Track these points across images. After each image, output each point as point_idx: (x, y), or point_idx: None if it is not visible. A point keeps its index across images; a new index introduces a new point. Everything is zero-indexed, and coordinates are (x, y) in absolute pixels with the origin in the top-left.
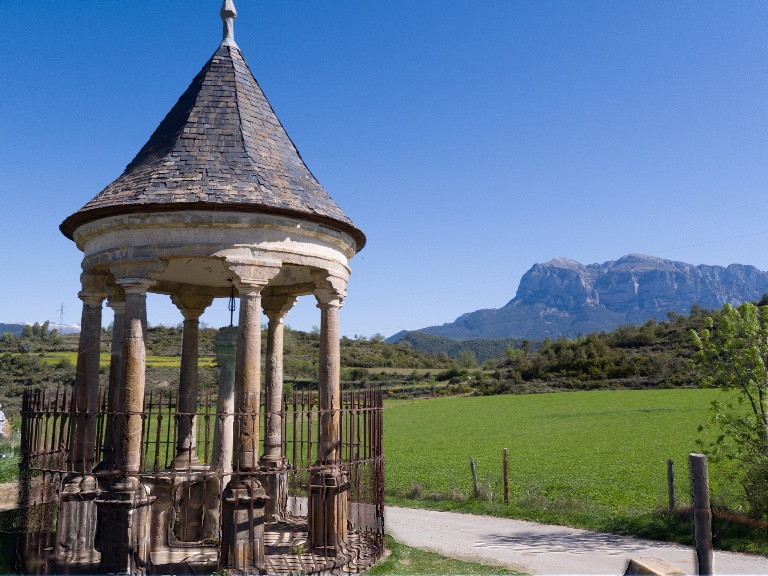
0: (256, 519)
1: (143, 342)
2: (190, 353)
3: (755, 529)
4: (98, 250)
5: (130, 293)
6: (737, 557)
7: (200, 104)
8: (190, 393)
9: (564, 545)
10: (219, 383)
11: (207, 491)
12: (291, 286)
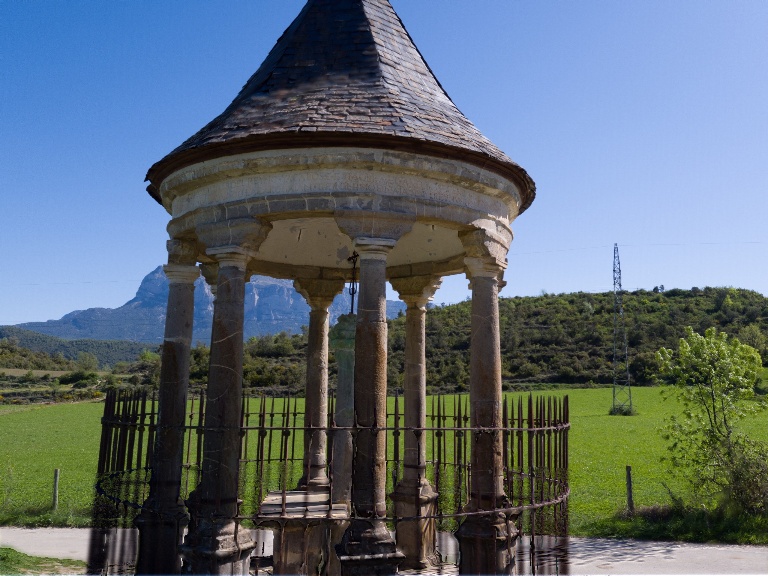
0: (511, 560)
1: None
2: None
3: (744, 524)
4: (302, 190)
5: (377, 259)
6: (756, 549)
7: (375, 23)
8: None
9: (605, 554)
10: (342, 387)
11: (332, 530)
12: (350, 270)
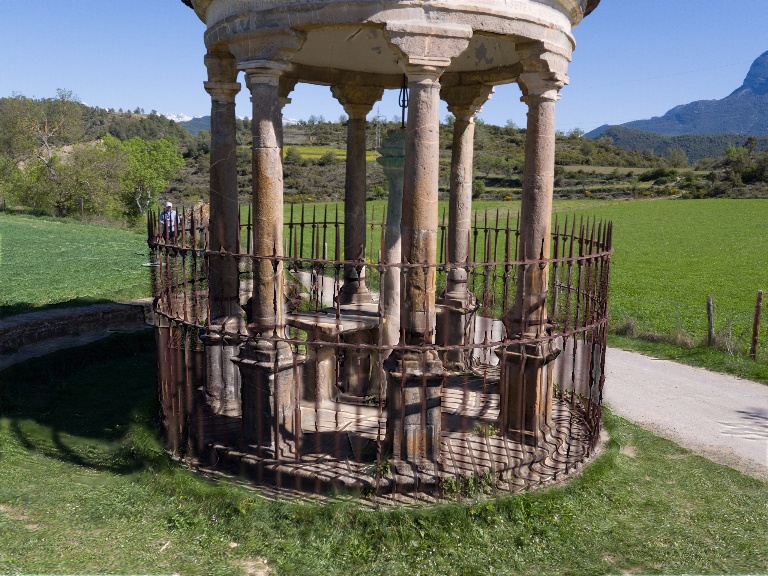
0: (430, 400)
1: (277, 154)
2: (356, 162)
3: None
4: (216, 21)
5: (256, 83)
6: None
7: None
8: (357, 212)
9: None
10: None
11: (374, 339)
12: (485, 71)
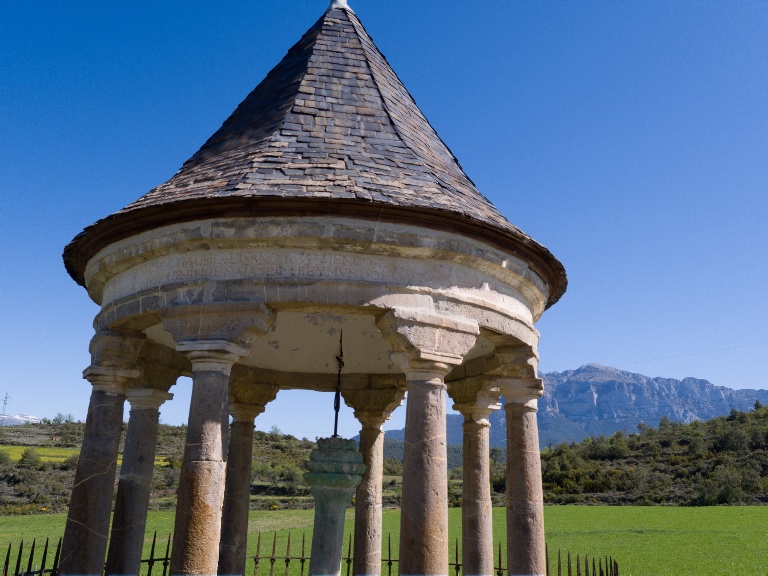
0: None
1: (223, 470)
2: (241, 476)
3: None
4: (139, 288)
5: (204, 370)
6: None
7: (315, 71)
8: (237, 543)
9: None
10: (314, 538)
11: None
12: (402, 375)
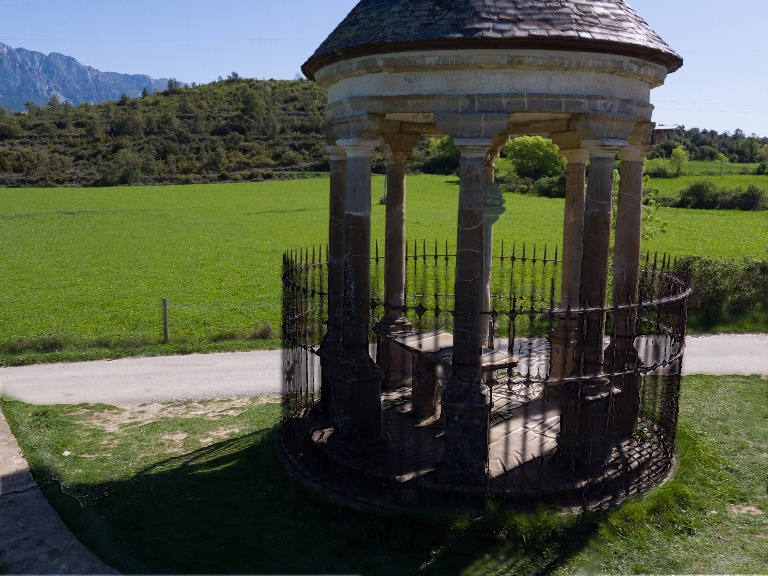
0: None
1: None
2: None
3: None
4: (559, 91)
5: (613, 157)
6: None
7: None
8: None
9: None
10: None
11: None
12: (426, 124)
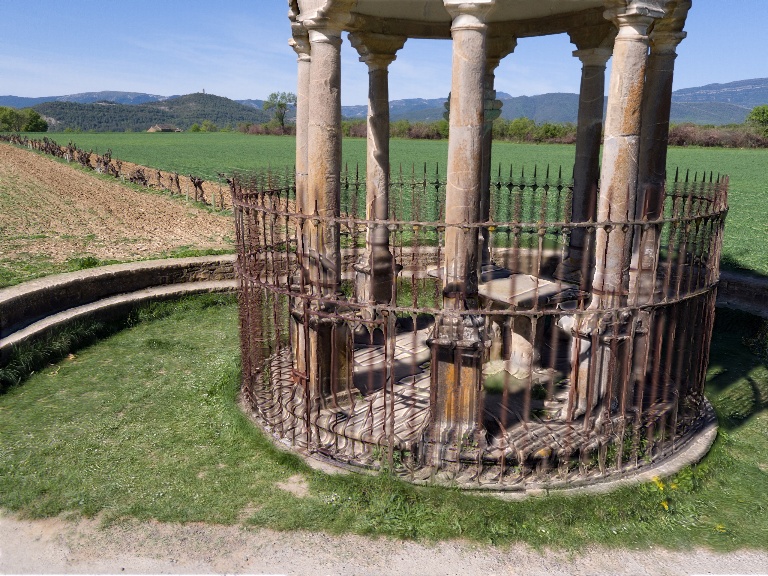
0: None
1: None
2: None
3: None
4: None
5: None
6: None
7: None
8: None
9: None
10: None
11: None
12: None
